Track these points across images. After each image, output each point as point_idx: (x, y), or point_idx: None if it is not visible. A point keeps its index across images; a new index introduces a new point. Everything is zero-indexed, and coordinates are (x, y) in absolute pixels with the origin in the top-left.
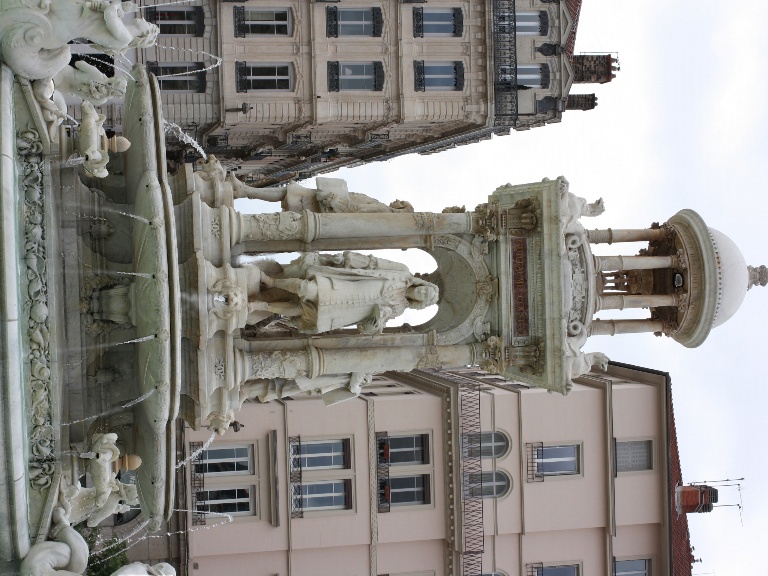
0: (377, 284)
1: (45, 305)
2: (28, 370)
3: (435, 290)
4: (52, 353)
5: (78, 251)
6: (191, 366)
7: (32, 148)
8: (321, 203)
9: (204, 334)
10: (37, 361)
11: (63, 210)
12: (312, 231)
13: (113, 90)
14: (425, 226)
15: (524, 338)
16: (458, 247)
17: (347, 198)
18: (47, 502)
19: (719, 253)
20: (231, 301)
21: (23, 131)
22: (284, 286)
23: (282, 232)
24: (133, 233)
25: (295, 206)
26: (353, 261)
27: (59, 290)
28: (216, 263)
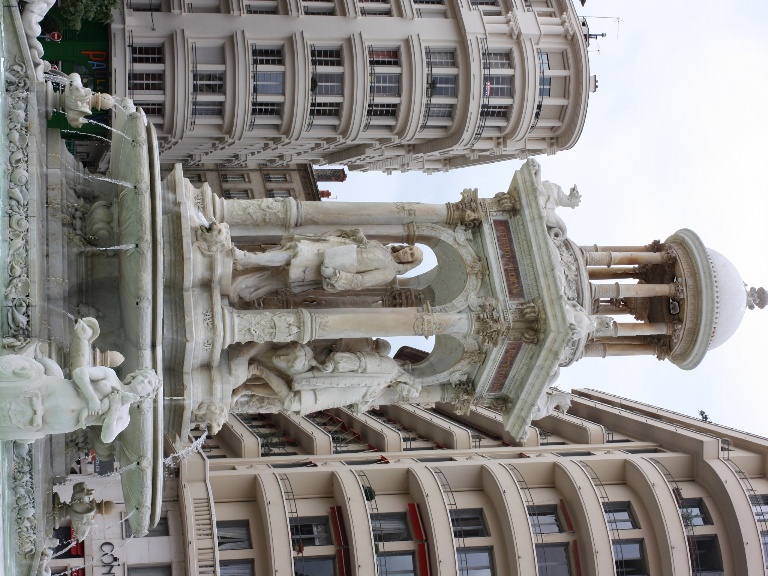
0: (361, 391)
1: (32, 508)
2: (16, 535)
3: (417, 392)
4: (38, 528)
5: None
6: None
7: None
8: (324, 279)
9: None
10: (24, 534)
11: None
12: (306, 342)
13: None
14: None
15: (496, 393)
16: None
17: (353, 265)
18: (32, 571)
19: (717, 328)
20: None
21: None
22: None
23: (276, 341)
24: None
25: (297, 277)
26: (342, 370)
27: None
28: (205, 363)
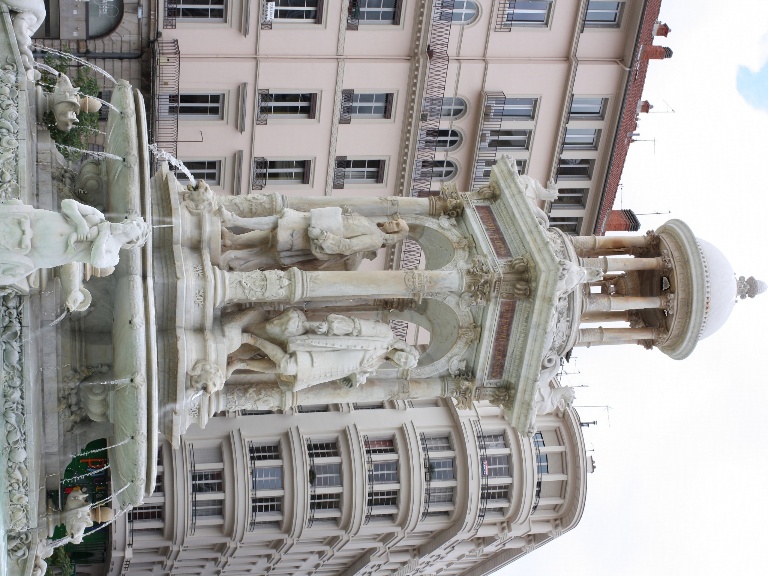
0: (358, 355)
1: (24, 450)
2: (7, 497)
3: (415, 359)
4: (30, 485)
5: (57, 358)
6: (166, 414)
7: (10, 293)
8: (312, 241)
9: (180, 413)
10: (16, 493)
11: (42, 312)
12: (298, 297)
13: None
14: (415, 291)
15: (497, 381)
16: (446, 298)
17: (340, 229)
18: None
19: (710, 298)
20: None
21: (1, 287)
22: None
23: (268, 297)
24: (114, 327)
25: (285, 241)
26: (337, 330)
27: None
28: (197, 327)
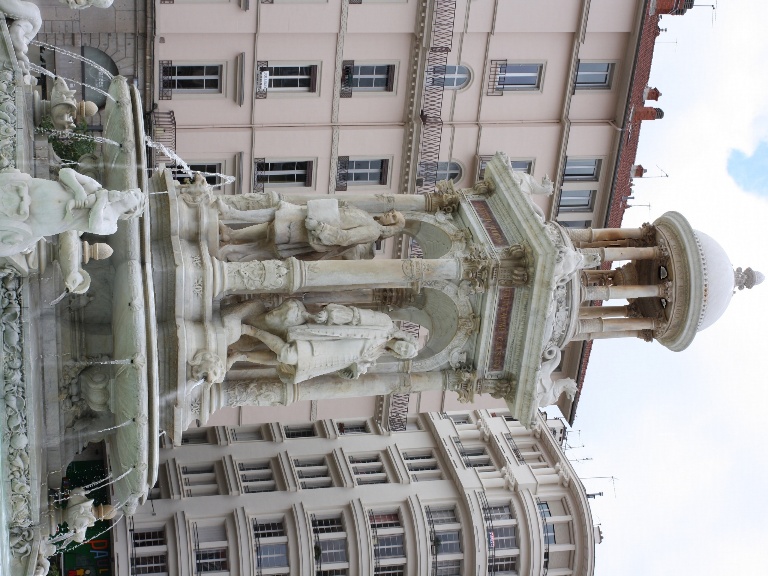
0: (358, 344)
1: (25, 435)
2: (8, 487)
3: (415, 347)
4: (32, 473)
5: (57, 346)
6: (167, 409)
7: (10, 275)
8: (309, 232)
9: (181, 404)
10: (17, 482)
11: (41, 299)
12: (297, 286)
13: (93, 2)
14: (413, 278)
15: (498, 372)
16: (445, 288)
17: (337, 221)
18: (27, 575)
19: (708, 286)
20: (210, 382)
21: (0, 267)
22: (264, 342)
23: (266, 287)
24: None
25: (282, 233)
26: (336, 319)
27: (38, 397)
28: (197, 318)
